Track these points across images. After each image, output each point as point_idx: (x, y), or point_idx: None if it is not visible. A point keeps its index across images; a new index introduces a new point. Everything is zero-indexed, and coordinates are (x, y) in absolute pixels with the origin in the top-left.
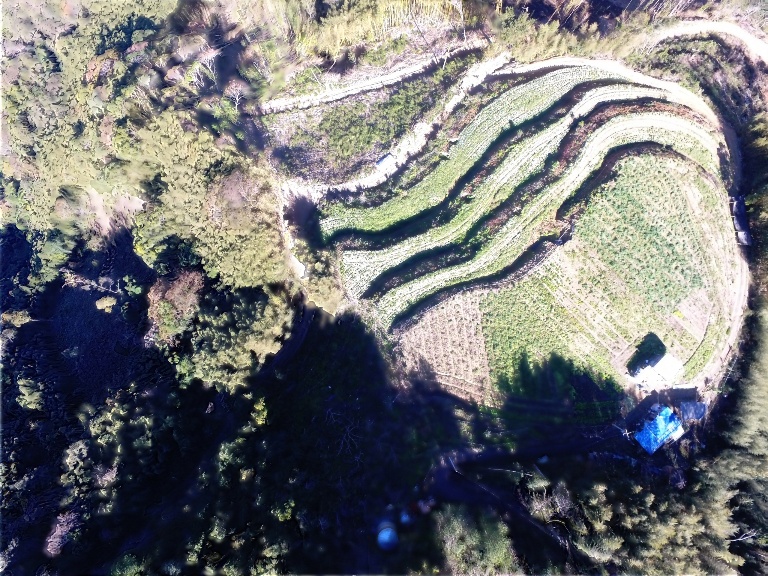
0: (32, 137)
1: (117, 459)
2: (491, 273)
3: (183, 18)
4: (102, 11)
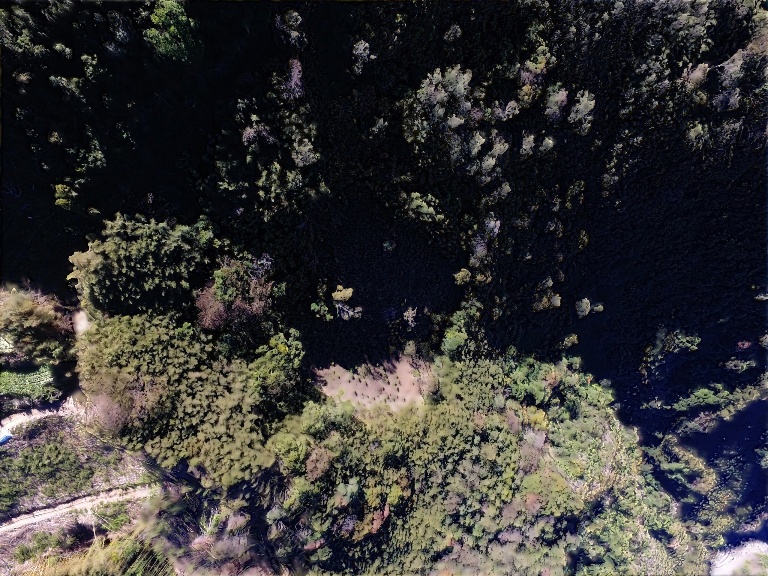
0: (482, 450)
1: (252, 149)
2: None
3: (297, 571)
4: (399, 575)
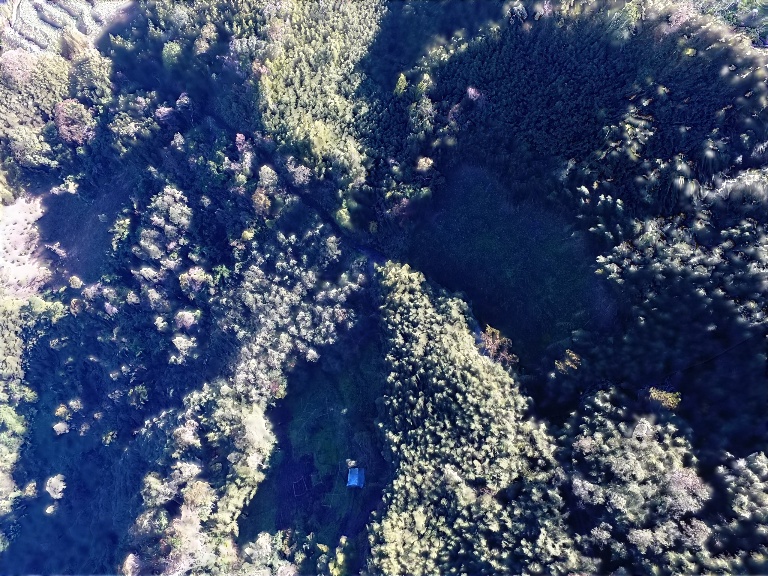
0: None
1: None
2: (91, 6)
3: None
4: None
